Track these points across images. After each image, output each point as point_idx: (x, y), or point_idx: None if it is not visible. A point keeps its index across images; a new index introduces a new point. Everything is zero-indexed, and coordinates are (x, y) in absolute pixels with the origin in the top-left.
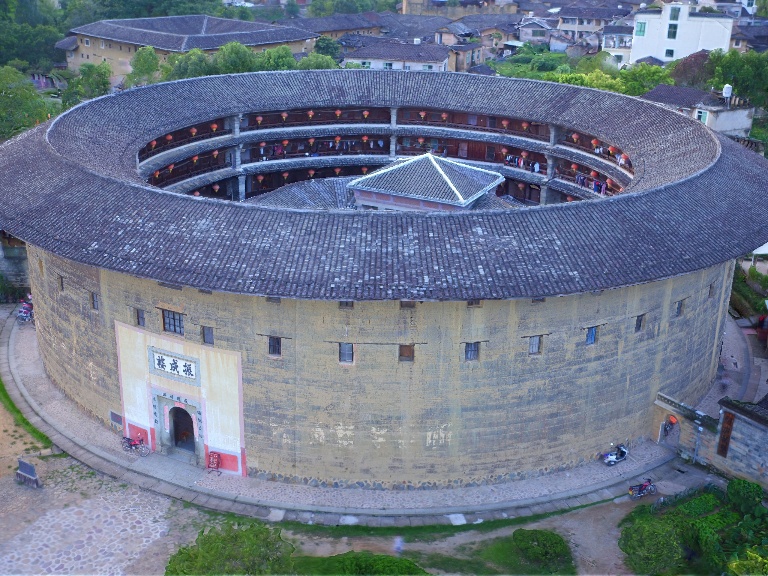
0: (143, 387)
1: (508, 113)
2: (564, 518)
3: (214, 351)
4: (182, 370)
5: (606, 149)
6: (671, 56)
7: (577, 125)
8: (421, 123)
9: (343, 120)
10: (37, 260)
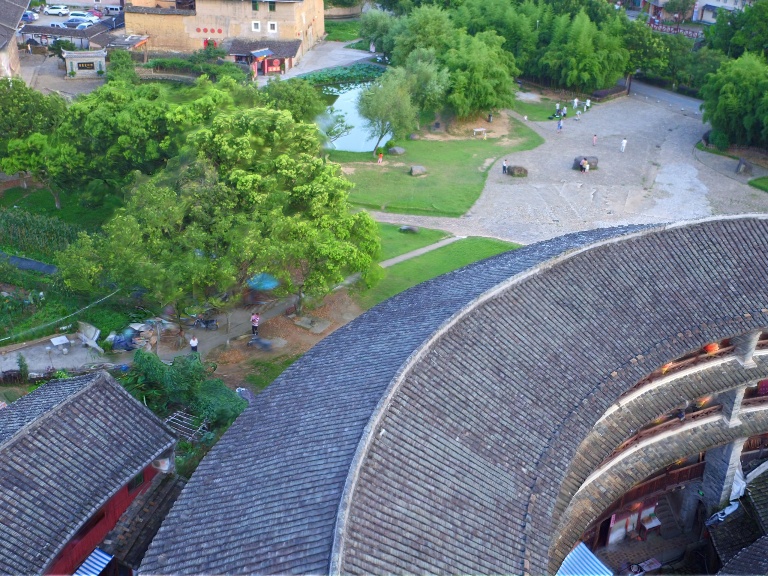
0: None
1: None
2: None
3: None
4: None
5: None
6: None
7: None
8: None
9: None
10: None
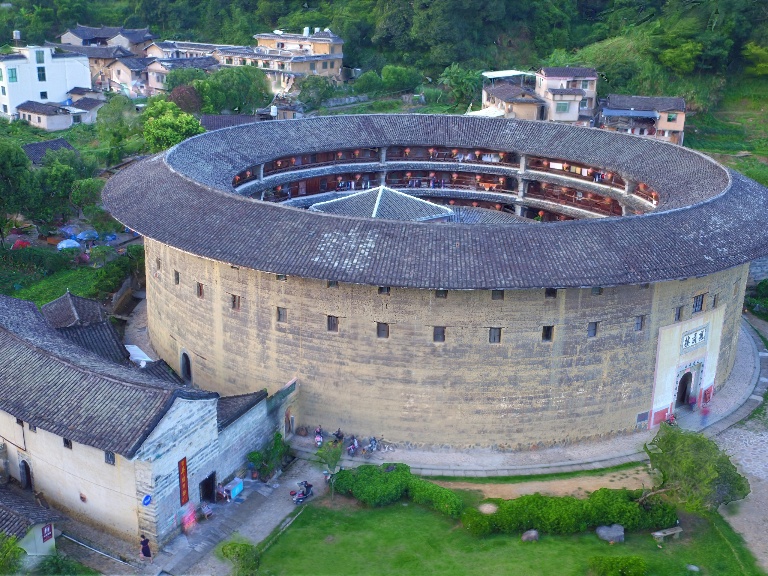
0: (673, 371)
1: (348, 145)
2: (763, 332)
3: None
4: None
5: (444, 153)
6: (46, 98)
7: (414, 141)
8: (273, 172)
9: (233, 185)
10: (539, 330)
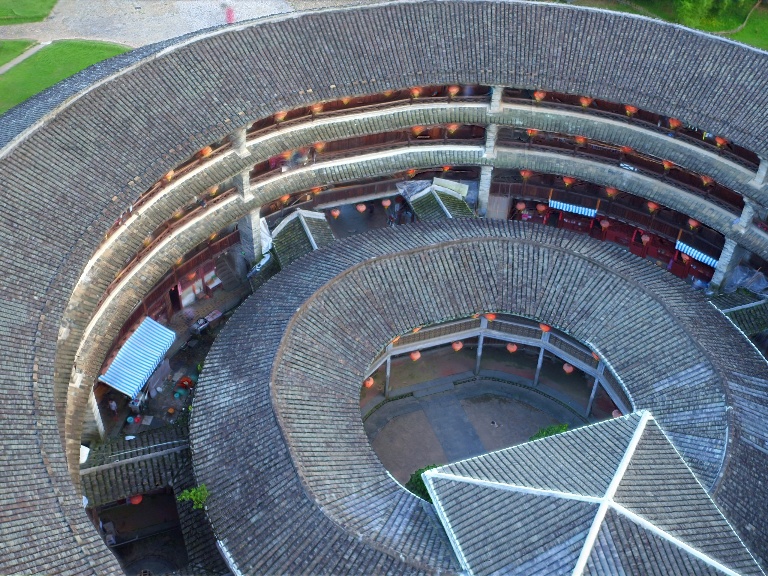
0: None
1: None
2: None
3: None
4: None
5: None
6: None
7: None
8: None
9: None
10: None
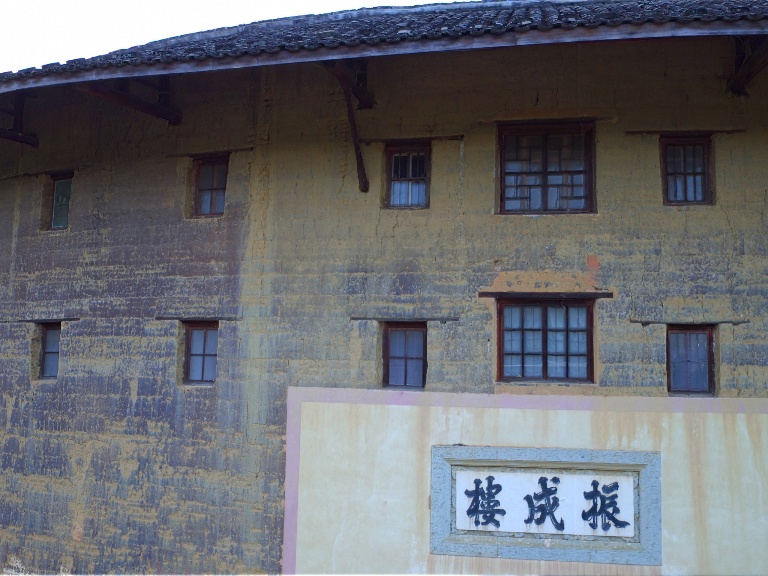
0: None
1: None
2: None
3: (721, 410)
4: (576, 513)
5: None
6: None
7: None
8: None
9: None
10: None
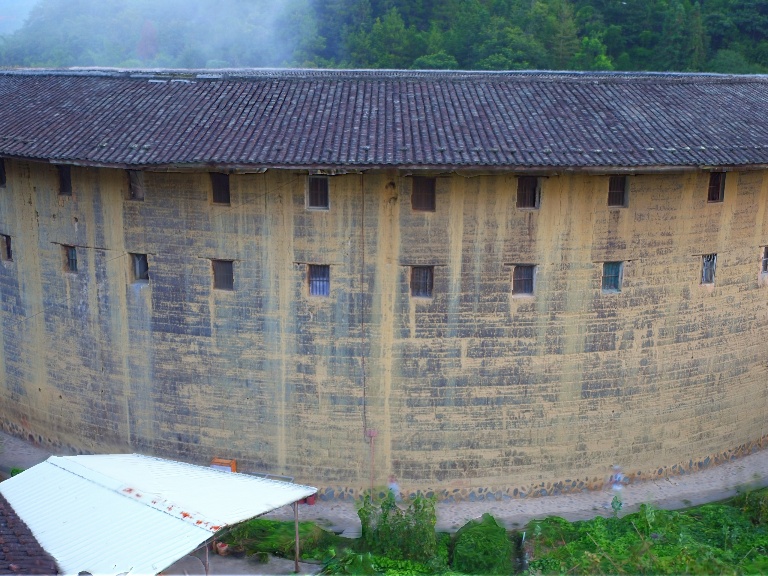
0: None
1: None
2: None
3: None
4: None
5: None
6: None
7: None
8: None
9: None
10: None
